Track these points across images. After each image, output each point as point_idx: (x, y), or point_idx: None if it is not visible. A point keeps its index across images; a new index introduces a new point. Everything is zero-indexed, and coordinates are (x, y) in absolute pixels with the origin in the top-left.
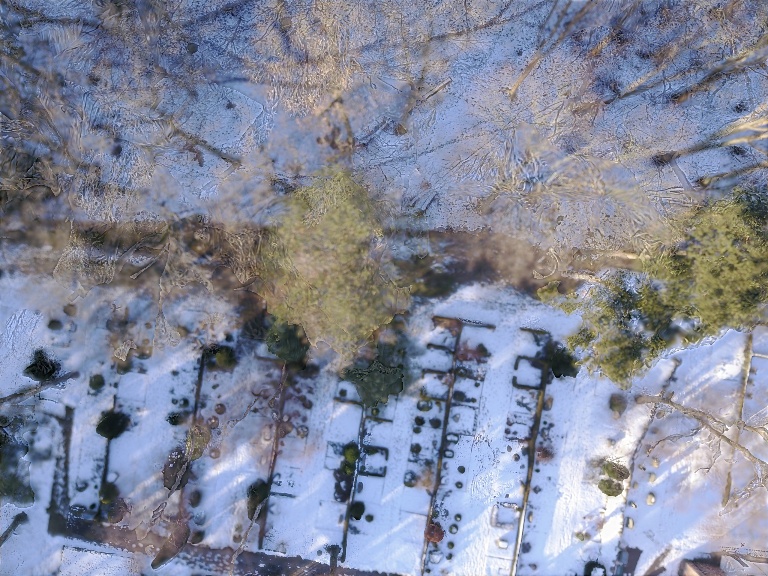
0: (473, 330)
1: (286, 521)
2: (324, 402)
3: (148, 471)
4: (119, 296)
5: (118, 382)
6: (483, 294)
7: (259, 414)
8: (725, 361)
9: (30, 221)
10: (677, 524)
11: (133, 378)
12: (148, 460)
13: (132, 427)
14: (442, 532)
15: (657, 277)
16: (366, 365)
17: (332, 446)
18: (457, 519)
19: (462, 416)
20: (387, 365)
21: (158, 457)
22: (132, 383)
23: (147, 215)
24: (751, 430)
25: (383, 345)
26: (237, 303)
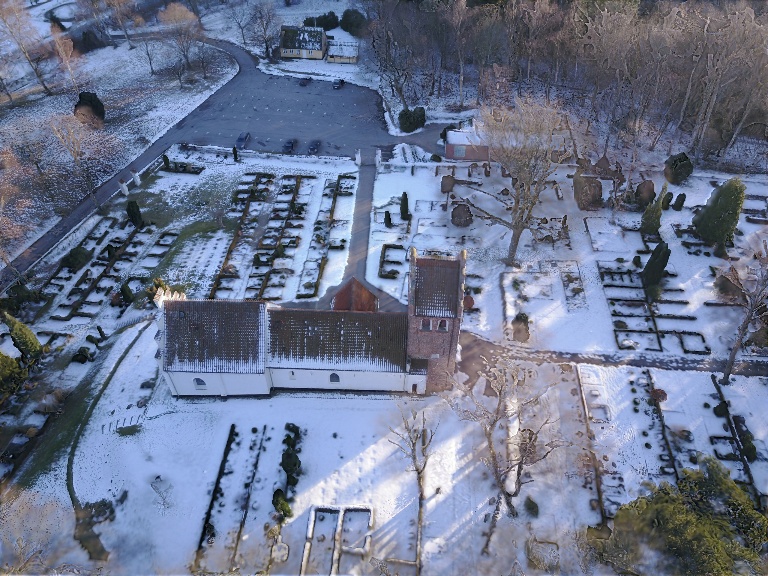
0: None
1: None
2: None
3: None
4: None
5: None
6: None
7: None
8: (440, 556)
9: None
10: None
11: None
12: None
13: None
14: (654, 396)
15: None
16: None
17: (766, 459)
18: None
19: None
20: None
21: None
22: None
23: None
24: None
25: None
26: None
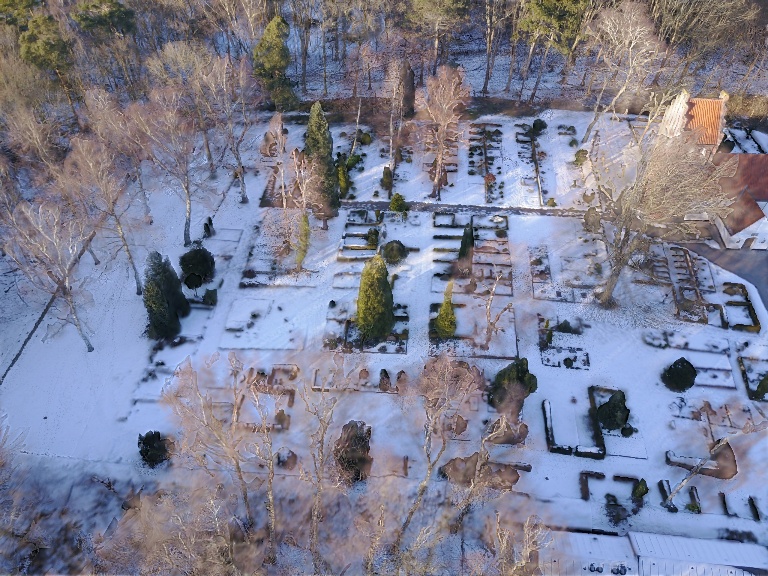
0: None
1: (404, 189)
2: (419, 152)
3: None
4: None
5: None
6: (493, 118)
7: (384, 158)
8: None
9: (273, 102)
10: None
11: None
12: None
13: None
14: (494, 177)
15: None
16: None
17: (426, 164)
18: (502, 182)
19: (494, 152)
20: None
21: None
22: None
23: (329, 98)
24: (642, 136)
25: None
26: (371, 126)
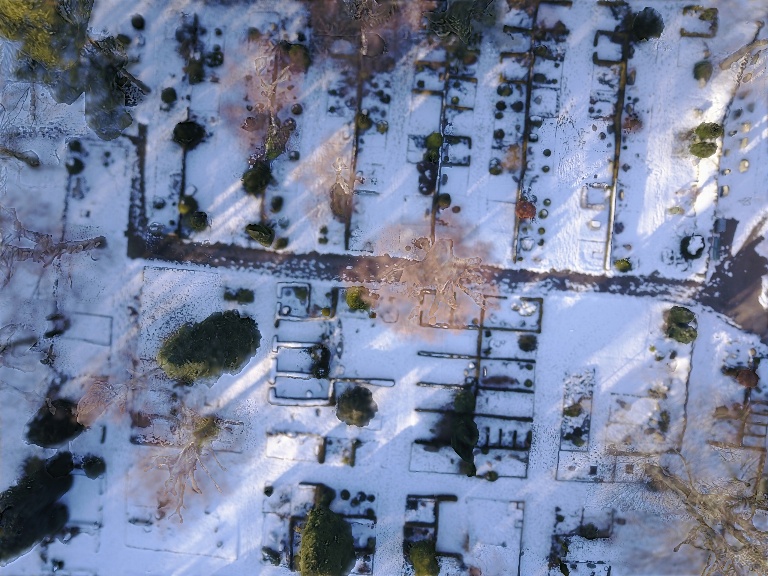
0: (549, 9)
1: (371, 219)
2: (402, 96)
3: (226, 182)
4: (187, 4)
5: (190, 95)
6: None
7: (336, 114)
8: None
9: None
10: None
11: (205, 88)
12: (226, 170)
13: (208, 137)
14: (534, 207)
15: None
16: (443, 52)
17: (413, 139)
18: (547, 202)
19: (544, 98)
20: (464, 49)
21: (236, 166)
22: (205, 94)
23: None
24: None
25: None
26: (307, 1)
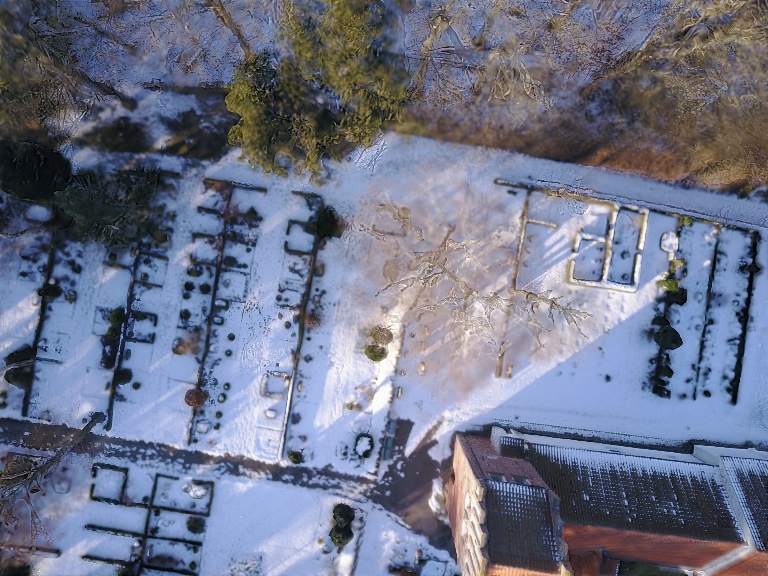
0: (244, 193)
1: (52, 388)
2: (93, 266)
3: None
4: None
5: None
6: None
7: (28, 278)
8: (500, 228)
9: None
10: (449, 395)
11: None
12: None
13: None
14: (203, 396)
15: (277, 40)
16: (135, 228)
17: (100, 311)
18: (224, 387)
19: (233, 282)
20: (155, 227)
21: None
22: None
23: None
24: (516, 292)
25: (152, 207)
26: None
